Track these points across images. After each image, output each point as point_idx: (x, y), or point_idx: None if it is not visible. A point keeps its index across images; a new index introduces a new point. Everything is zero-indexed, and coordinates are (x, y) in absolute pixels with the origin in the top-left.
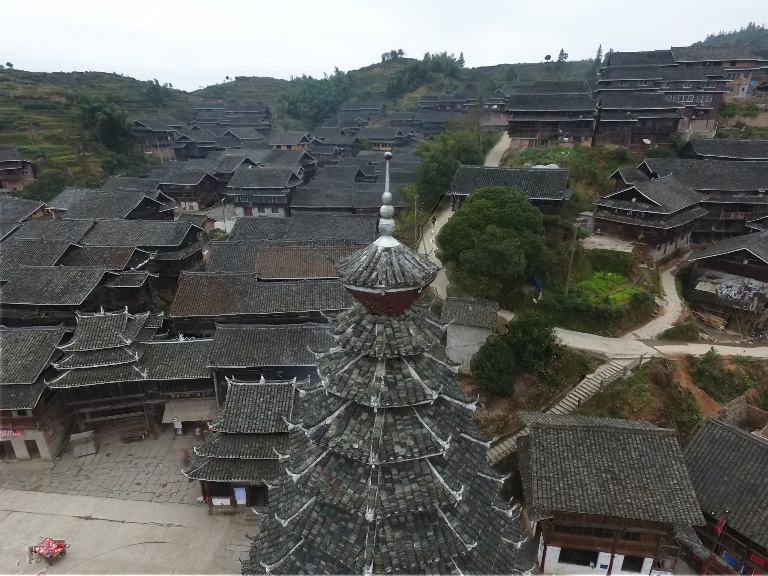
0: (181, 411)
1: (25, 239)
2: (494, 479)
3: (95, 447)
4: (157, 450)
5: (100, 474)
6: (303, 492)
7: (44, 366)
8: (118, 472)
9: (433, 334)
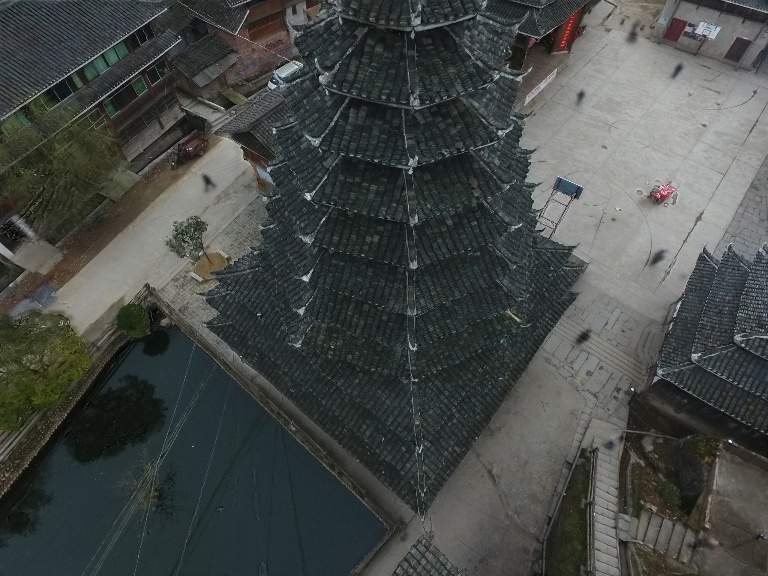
0: None
1: None
2: None
3: None
4: None
5: (767, 229)
6: None
7: None
8: None
9: None
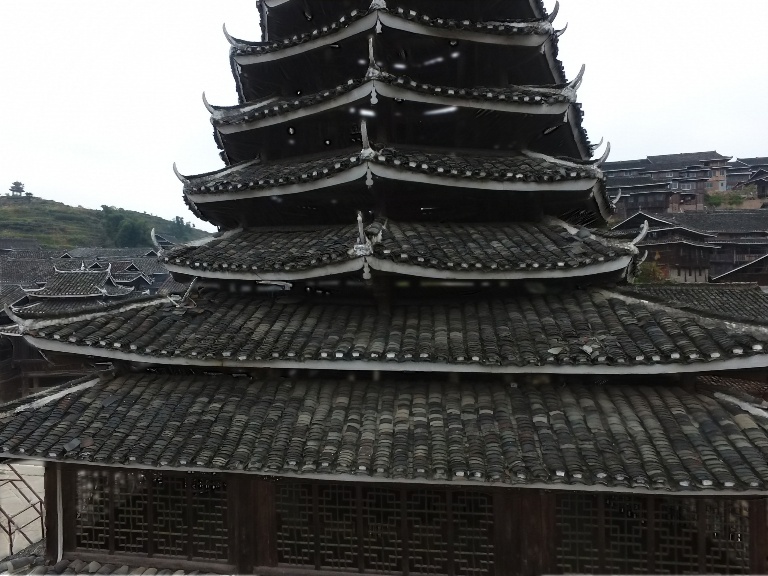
0: None
1: (22, 249)
2: None
3: None
4: None
5: None
6: None
7: (1, 311)
8: None
9: None
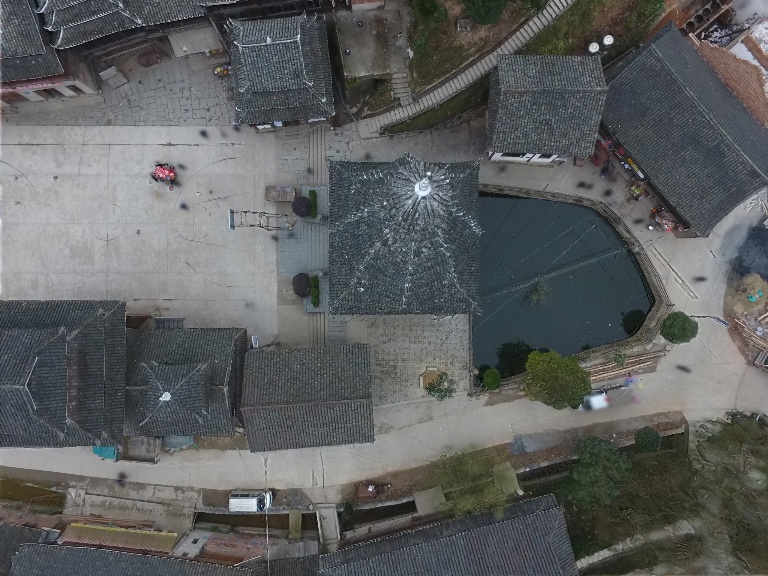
0: (187, 43)
1: None
2: (467, 222)
3: (124, 78)
4: (179, 73)
5: (149, 104)
6: None
7: (38, 30)
8: (162, 100)
9: (445, 211)
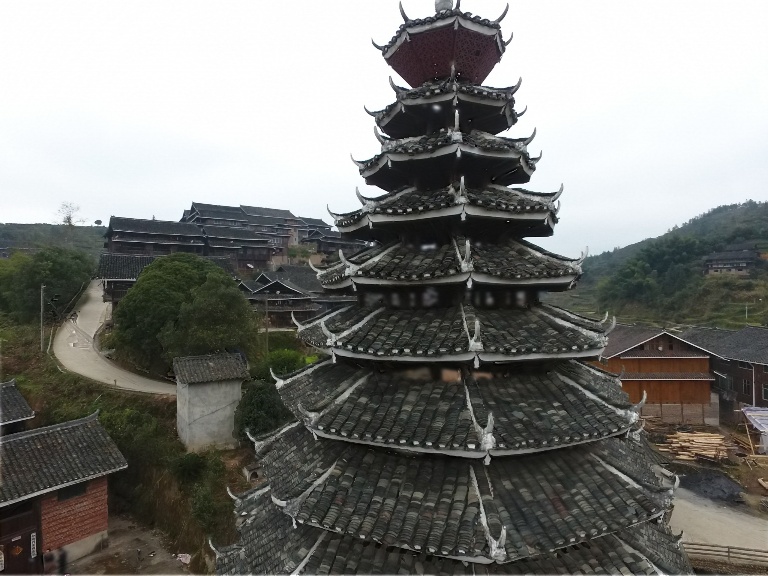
0: None
1: None
2: None
3: None
4: None
5: None
6: (444, 326)
7: None
8: None
9: None
